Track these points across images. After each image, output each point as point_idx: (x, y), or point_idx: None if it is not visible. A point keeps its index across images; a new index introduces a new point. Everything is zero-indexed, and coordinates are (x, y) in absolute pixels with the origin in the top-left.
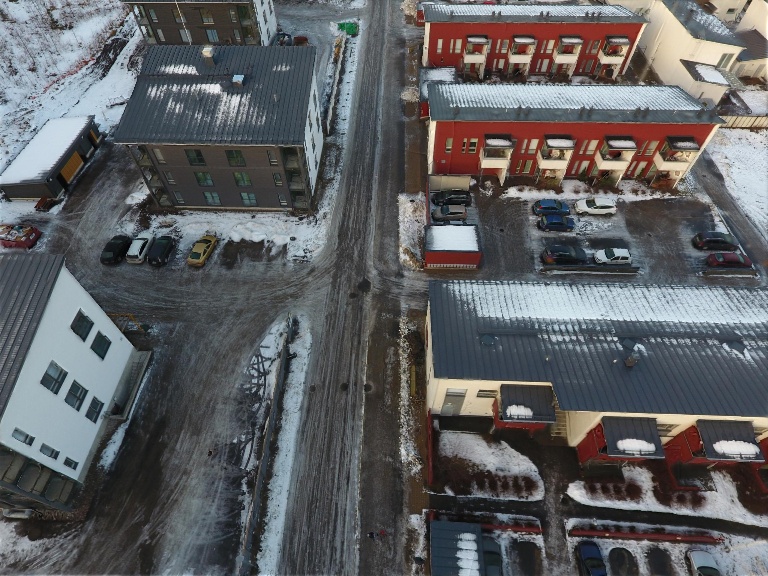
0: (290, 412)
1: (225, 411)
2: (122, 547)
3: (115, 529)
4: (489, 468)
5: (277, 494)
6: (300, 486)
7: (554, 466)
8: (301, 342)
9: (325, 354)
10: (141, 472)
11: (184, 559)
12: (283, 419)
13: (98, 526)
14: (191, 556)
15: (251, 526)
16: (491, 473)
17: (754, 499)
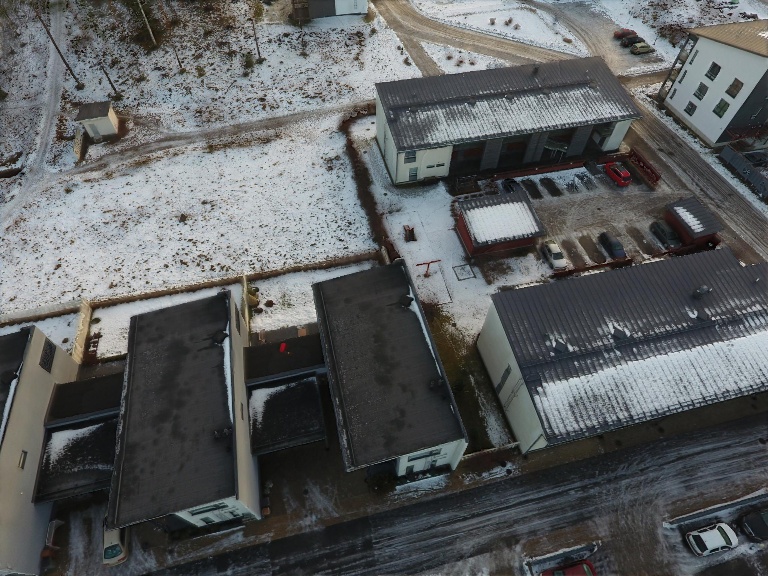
0: None
1: None
2: None
3: None
4: None
5: None
6: None
7: None
8: None
9: None
10: None
11: None
12: None
13: None
14: None
15: None
16: None
17: None
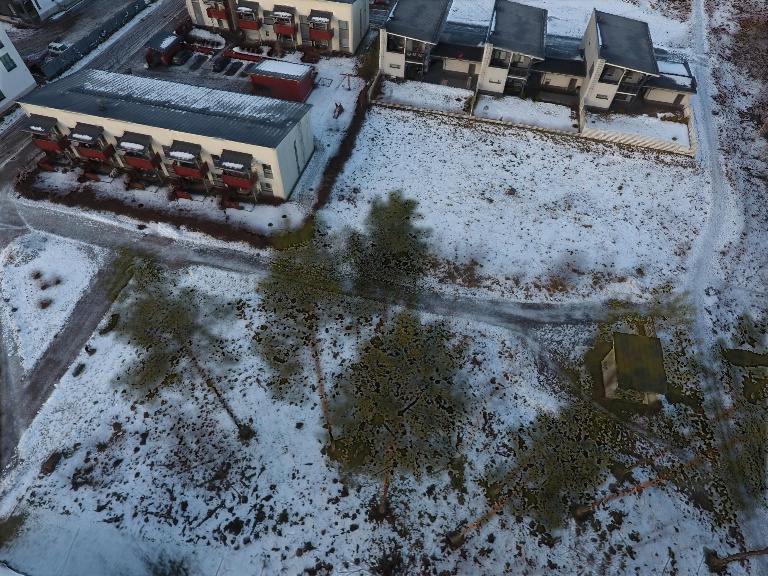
0: (136, 19)
1: (109, 15)
2: (50, 36)
3: (49, 32)
4: (205, 38)
5: (116, 34)
6: (127, 35)
7: (233, 42)
8: (156, 4)
9: (164, 8)
10: (66, 23)
11: (71, 41)
12: (132, 20)
13: (43, 30)
14: (74, 41)
15: (99, 33)
16: (205, 40)
17: (306, 58)
